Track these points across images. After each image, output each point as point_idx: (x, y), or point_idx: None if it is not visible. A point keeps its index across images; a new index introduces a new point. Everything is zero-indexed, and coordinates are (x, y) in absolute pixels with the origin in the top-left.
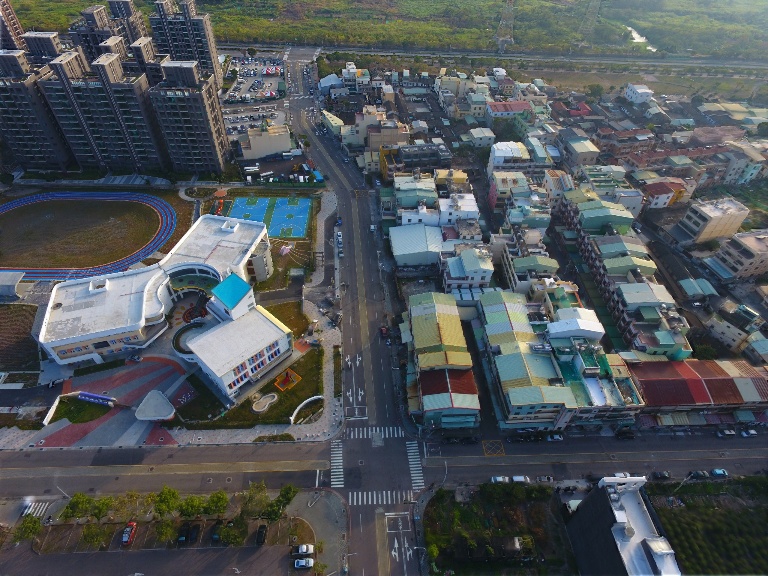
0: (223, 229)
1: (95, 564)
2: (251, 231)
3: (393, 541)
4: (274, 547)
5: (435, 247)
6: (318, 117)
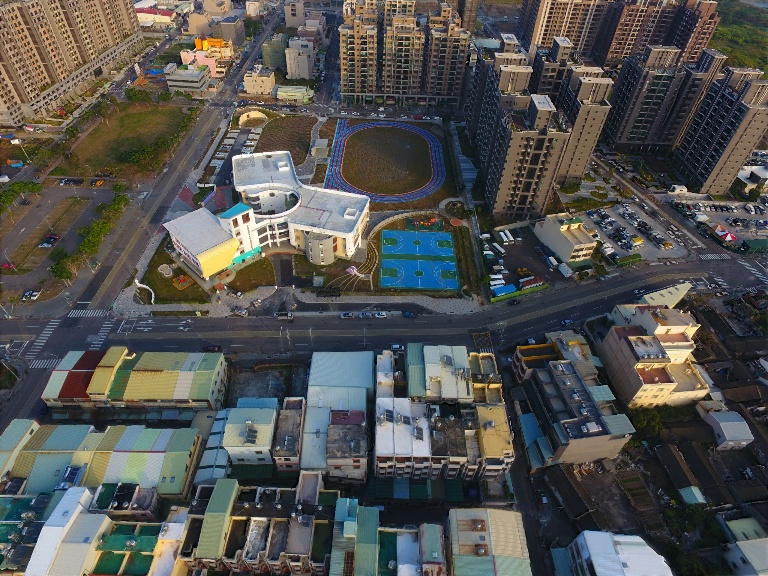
0: (347, 210)
1: (95, 218)
2: (344, 227)
3: (6, 344)
4: (51, 283)
5: (317, 396)
6: (695, 291)
